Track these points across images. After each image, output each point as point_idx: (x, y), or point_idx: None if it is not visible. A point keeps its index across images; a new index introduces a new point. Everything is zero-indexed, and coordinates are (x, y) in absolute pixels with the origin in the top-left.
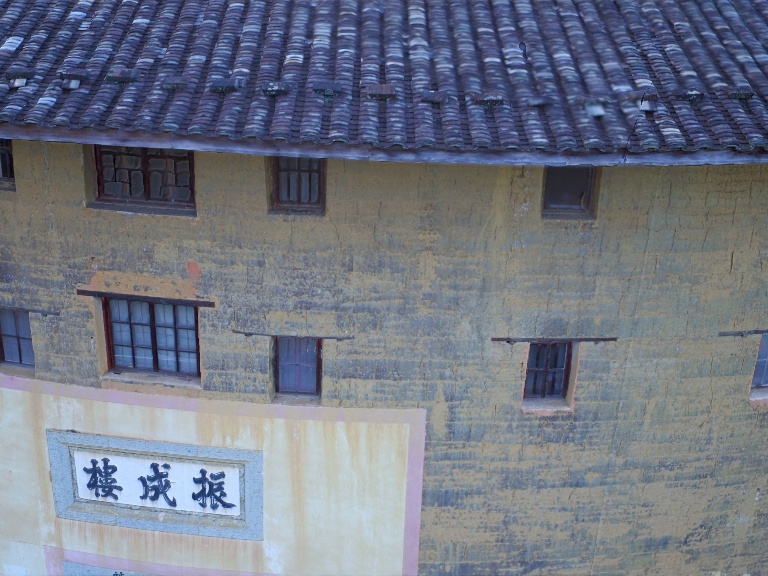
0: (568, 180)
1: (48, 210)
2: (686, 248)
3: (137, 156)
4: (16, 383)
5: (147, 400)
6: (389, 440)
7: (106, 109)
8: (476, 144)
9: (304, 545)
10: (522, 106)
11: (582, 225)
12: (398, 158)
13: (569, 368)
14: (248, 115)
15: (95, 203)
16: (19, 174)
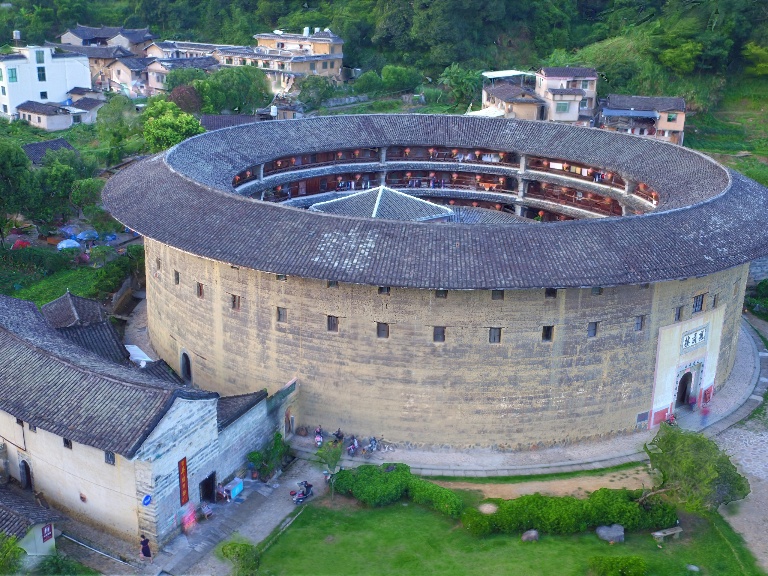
0: None
1: None
2: None
3: None
4: None
5: None
6: None
7: None
8: None
9: None
10: None
11: None
12: None
13: None
14: (762, 251)
15: None
16: None
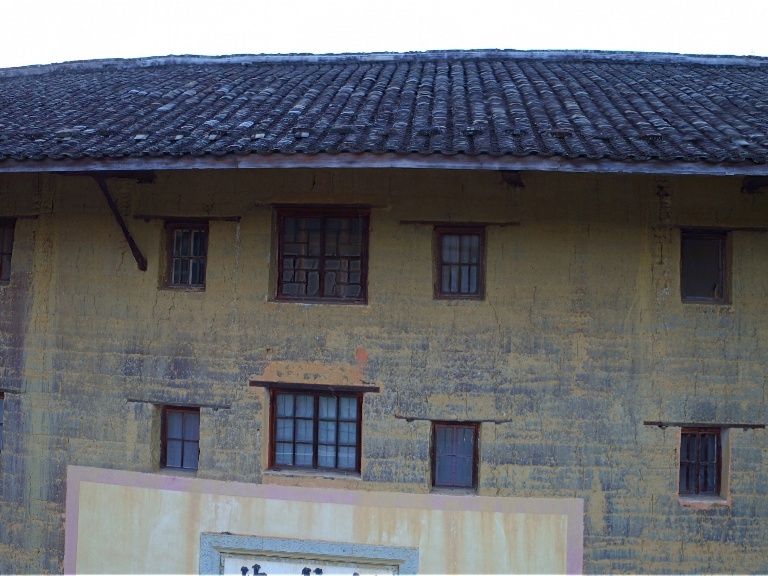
0: (701, 273)
1: (232, 306)
2: None
3: (315, 258)
4: (177, 483)
5: (306, 494)
6: (547, 534)
7: (335, 144)
8: (649, 154)
9: None
10: (678, 142)
11: (720, 309)
12: (583, 168)
13: (720, 462)
14: (454, 143)
15: (274, 300)
16: (211, 274)
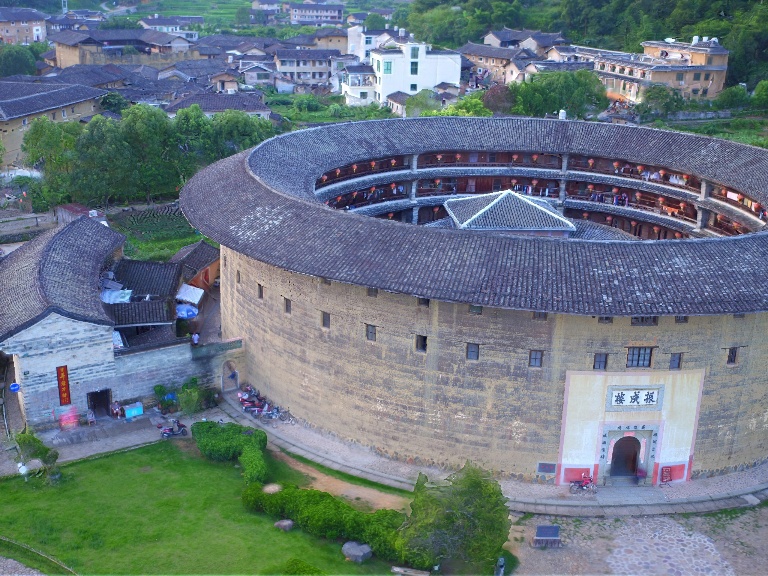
0: None
1: (621, 327)
2: (763, 322)
3: None
4: (602, 374)
5: (638, 374)
6: (696, 378)
7: None
8: None
9: (673, 410)
10: None
11: (742, 319)
12: None
13: (736, 355)
14: None
15: (631, 324)
16: (615, 319)
